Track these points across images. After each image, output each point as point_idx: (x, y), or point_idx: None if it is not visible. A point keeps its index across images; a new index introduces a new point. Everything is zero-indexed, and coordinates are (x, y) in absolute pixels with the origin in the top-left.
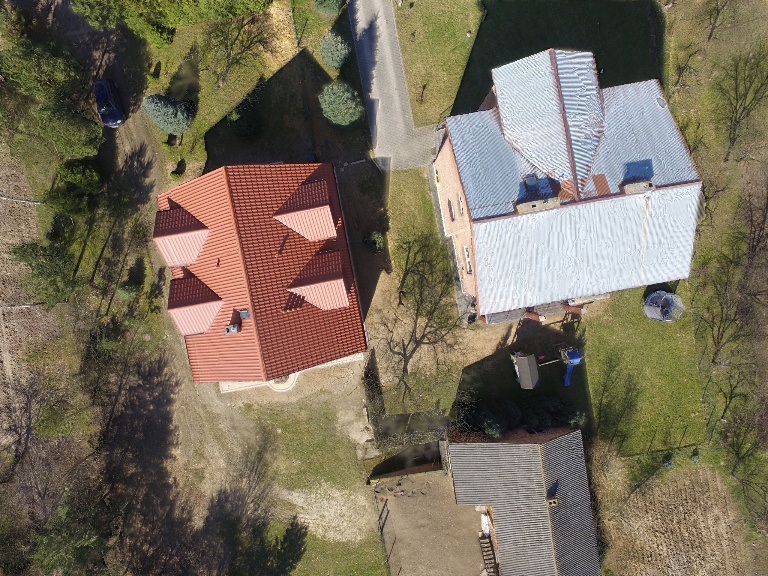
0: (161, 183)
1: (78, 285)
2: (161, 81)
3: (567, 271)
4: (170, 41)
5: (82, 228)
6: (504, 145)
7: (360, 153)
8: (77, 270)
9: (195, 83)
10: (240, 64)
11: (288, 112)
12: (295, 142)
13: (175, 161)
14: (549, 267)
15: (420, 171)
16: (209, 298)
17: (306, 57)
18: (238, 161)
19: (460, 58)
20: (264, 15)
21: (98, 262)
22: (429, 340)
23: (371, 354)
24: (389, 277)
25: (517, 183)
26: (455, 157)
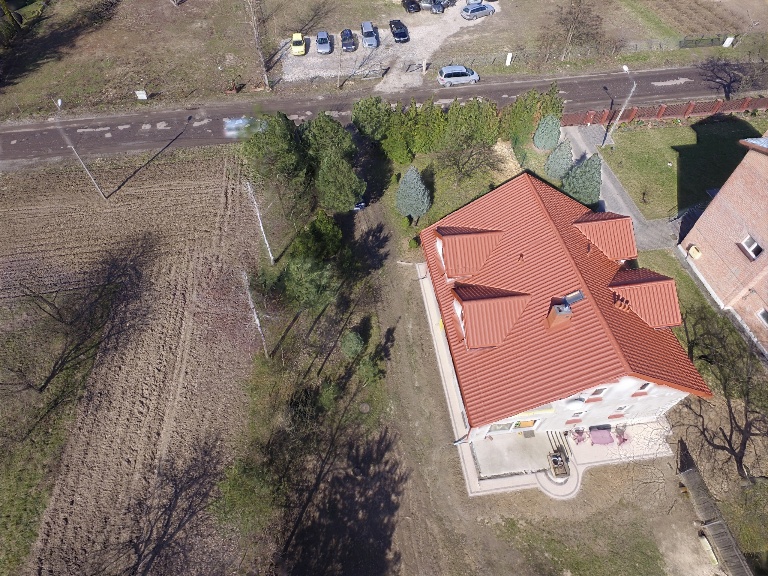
0: (395, 253)
1: None
2: None
3: None
4: (411, 161)
5: None
6: None
7: None
8: (291, 326)
9: (431, 186)
10: (471, 176)
11: None
12: None
13: (410, 237)
14: None
15: (666, 252)
16: (512, 294)
17: None
18: None
19: (669, 177)
20: (489, 150)
21: (318, 318)
22: (759, 430)
23: (681, 448)
24: None
25: None
26: None
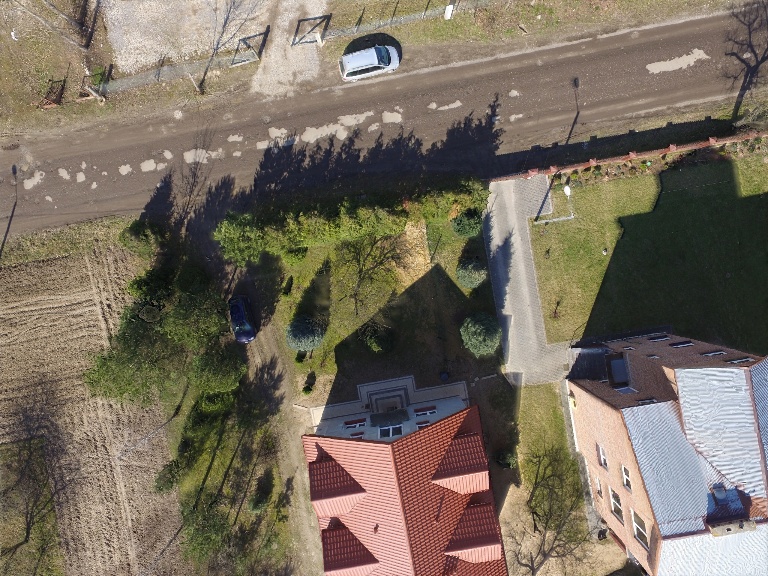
0: (291, 395)
1: (226, 529)
2: (292, 295)
3: (748, 571)
4: (303, 257)
5: (212, 438)
6: (685, 444)
7: (491, 368)
8: (206, 479)
9: (326, 297)
10: (372, 279)
11: (419, 327)
12: (426, 356)
13: (305, 373)
14: (729, 567)
15: (552, 387)
16: (365, 559)
17: (438, 272)
18: (368, 374)
19: (595, 275)
20: None
21: (227, 472)
22: (558, 553)
23: None
24: (518, 491)
25: (703, 492)
26: (637, 459)
